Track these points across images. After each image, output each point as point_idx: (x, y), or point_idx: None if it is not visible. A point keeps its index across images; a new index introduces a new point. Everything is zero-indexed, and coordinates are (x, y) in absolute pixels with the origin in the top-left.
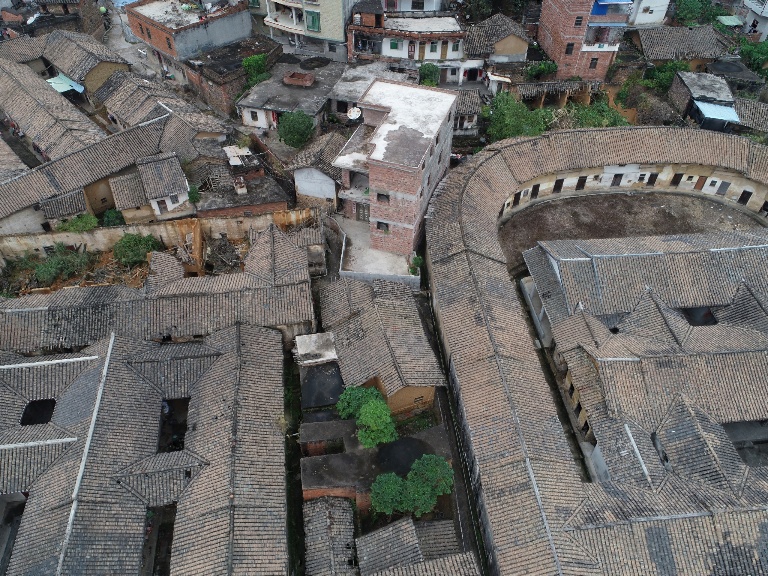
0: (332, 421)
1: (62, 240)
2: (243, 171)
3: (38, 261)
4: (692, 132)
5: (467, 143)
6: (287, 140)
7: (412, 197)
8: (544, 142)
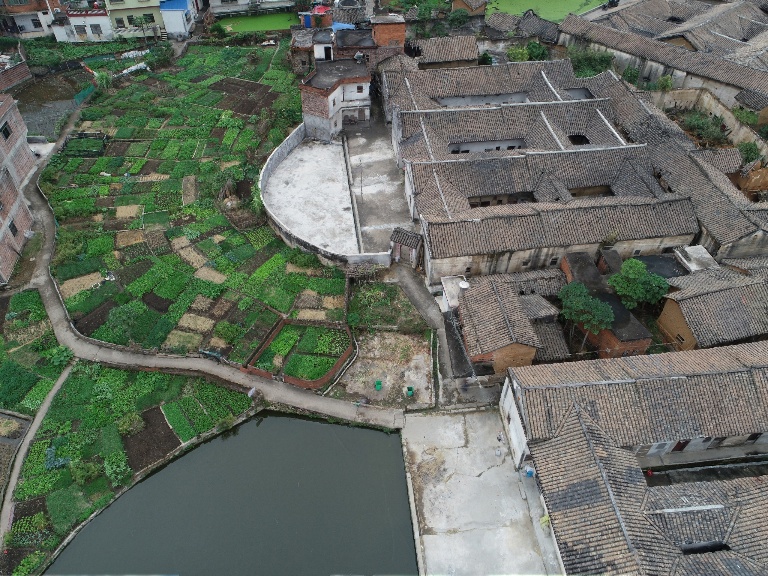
0: None
1: (725, 117)
2: None
3: None
4: None
5: None
6: None
7: None
8: None
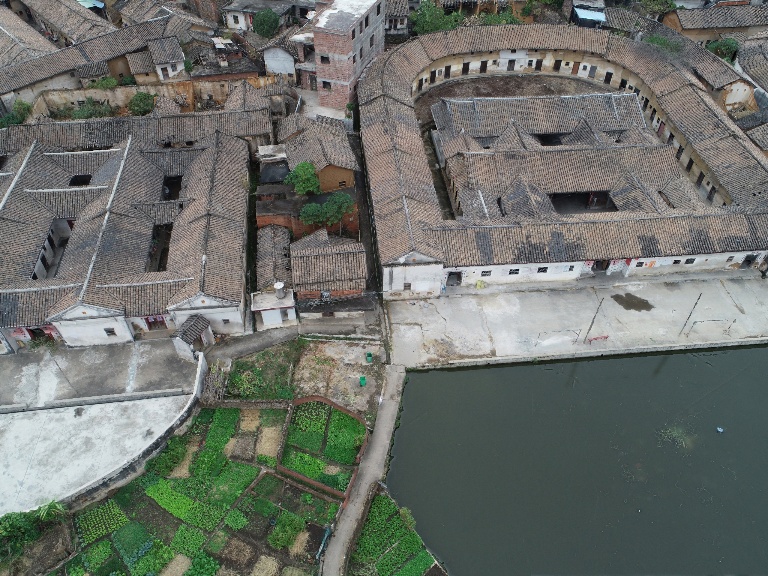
0: (279, 185)
1: (91, 95)
2: (226, 53)
3: (73, 112)
4: (567, 27)
5: (400, 41)
6: (259, 30)
7: (345, 57)
8: (453, 33)
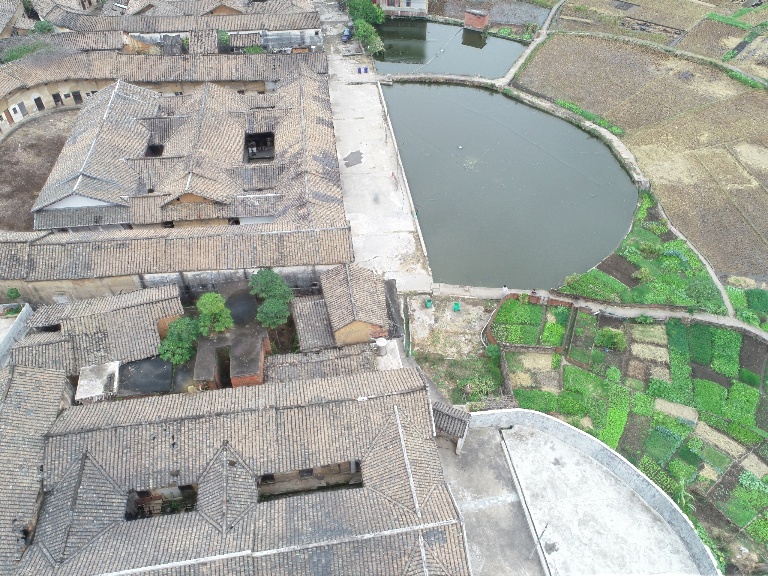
0: None
1: None
2: None
3: None
4: None
5: None
6: None
7: None
8: None
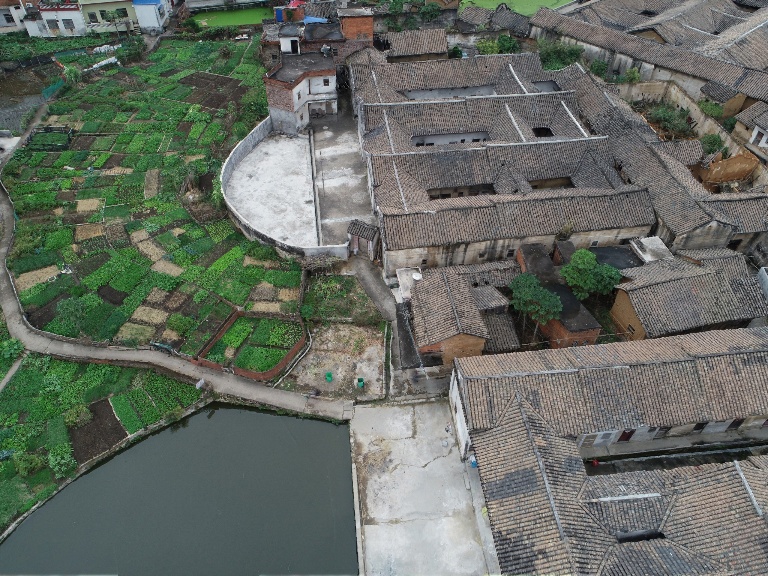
0: None
1: (691, 110)
2: None
3: None
4: None
5: None
6: None
7: None
8: None
